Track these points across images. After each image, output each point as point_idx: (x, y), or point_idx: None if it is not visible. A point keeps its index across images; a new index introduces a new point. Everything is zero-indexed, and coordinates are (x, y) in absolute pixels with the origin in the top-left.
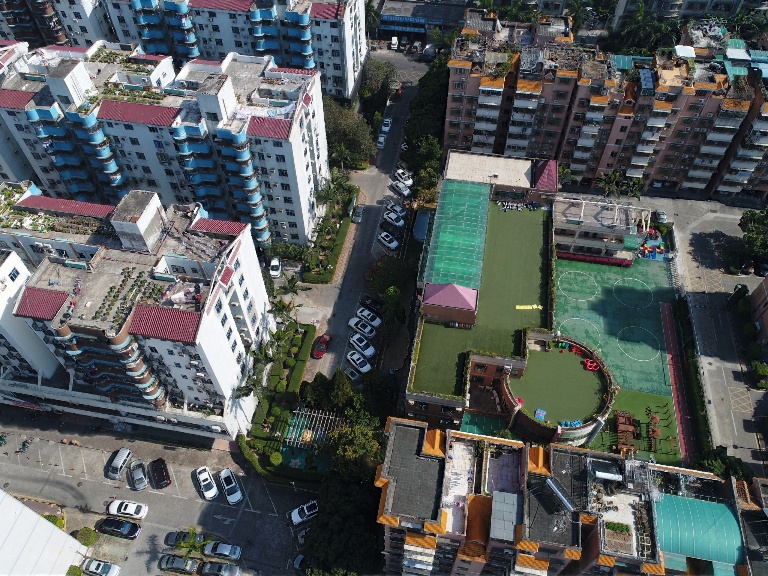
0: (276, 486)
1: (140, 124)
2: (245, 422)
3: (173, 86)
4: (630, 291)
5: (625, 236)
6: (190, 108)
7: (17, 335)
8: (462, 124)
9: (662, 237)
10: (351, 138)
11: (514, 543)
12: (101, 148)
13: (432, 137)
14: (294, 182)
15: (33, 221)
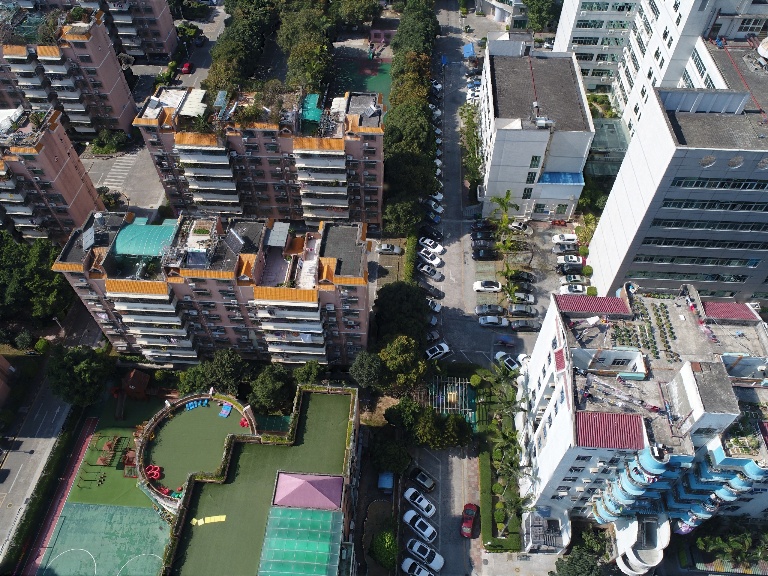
0: None
1: None
2: None
3: None
4: None
5: None
6: None
7: None
8: None
9: None
10: None
11: None
12: None
13: None
14: None
15: None
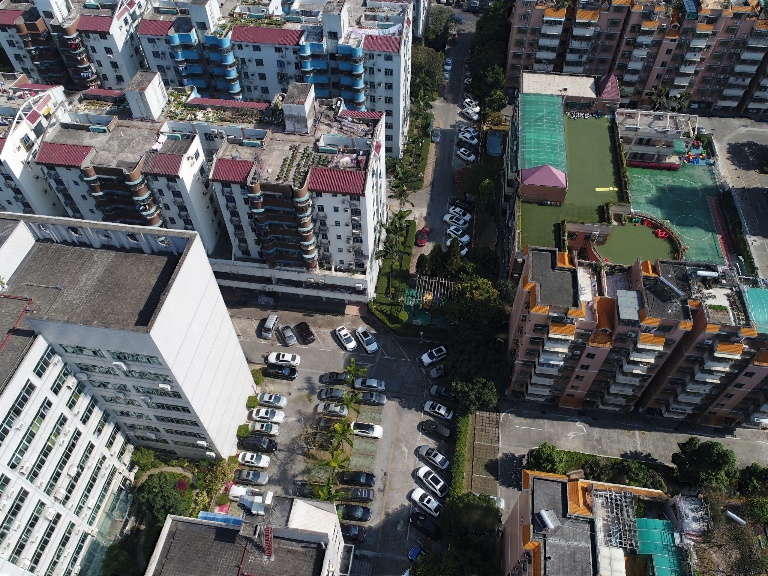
0: (404, 339)
1: (269, 45)
2: (372, 291)
3: (289, 15)
4: (680, 189)
5: (674, 143)
6: (309, 31)
7: (197, 208)
8: (524, 55)
9: (703, 147)
10: (425, 70)
11: (639, 322)
12: (231, 69)
13: (498, 67)
14: (397, 95)
15: (204, 115)
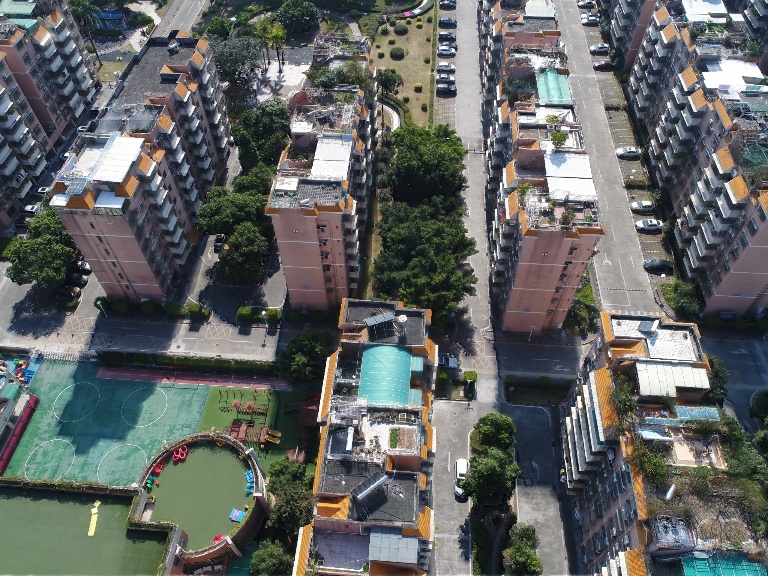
0: None
1: None
2: None
3: None
4: (73, 405)
5: None
6: None
7: None
8: None
9: (4, 360)
10: None
11: None
12: None
13: None
14: None
15: None
